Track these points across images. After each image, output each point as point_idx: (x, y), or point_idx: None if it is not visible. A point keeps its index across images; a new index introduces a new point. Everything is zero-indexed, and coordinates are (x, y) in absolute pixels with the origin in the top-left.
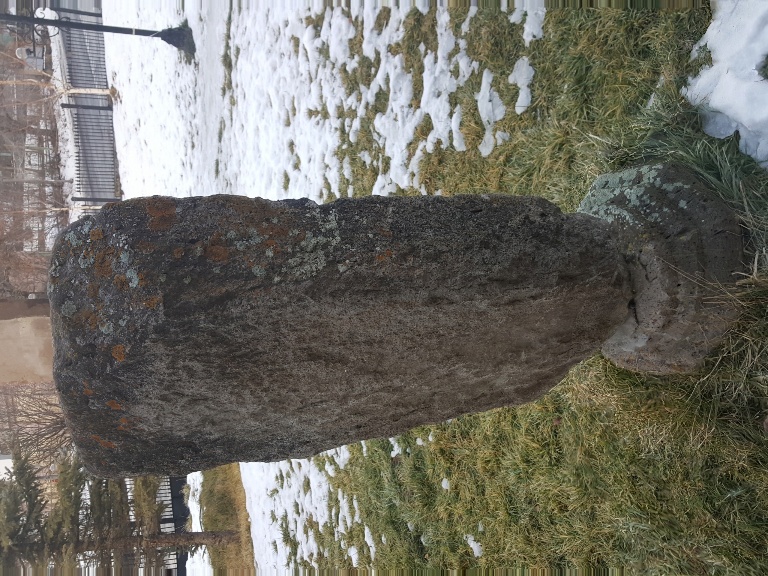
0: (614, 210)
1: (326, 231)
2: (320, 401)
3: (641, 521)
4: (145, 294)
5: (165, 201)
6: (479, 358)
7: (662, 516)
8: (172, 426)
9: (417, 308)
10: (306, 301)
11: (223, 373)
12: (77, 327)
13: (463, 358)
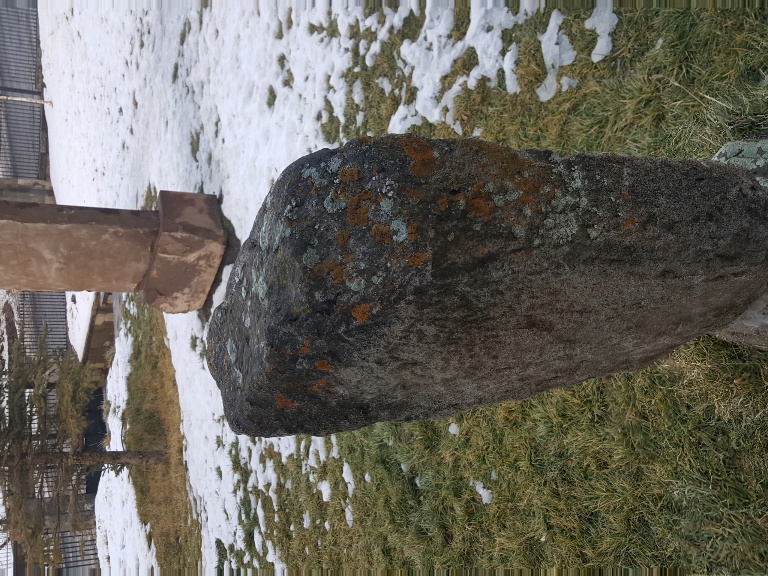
0: (763, 183)
1: (573, 191)
2: (505, 368)
3: (700, 485)
4: (412, 251)
5: (421, 143)
6: (648, 330)
7: (729, 483)
8: (366, 389)
9: (646, 281)
10: (562, 269)
11: (448, 338)
12: (318, 280)
13: (638, 329)
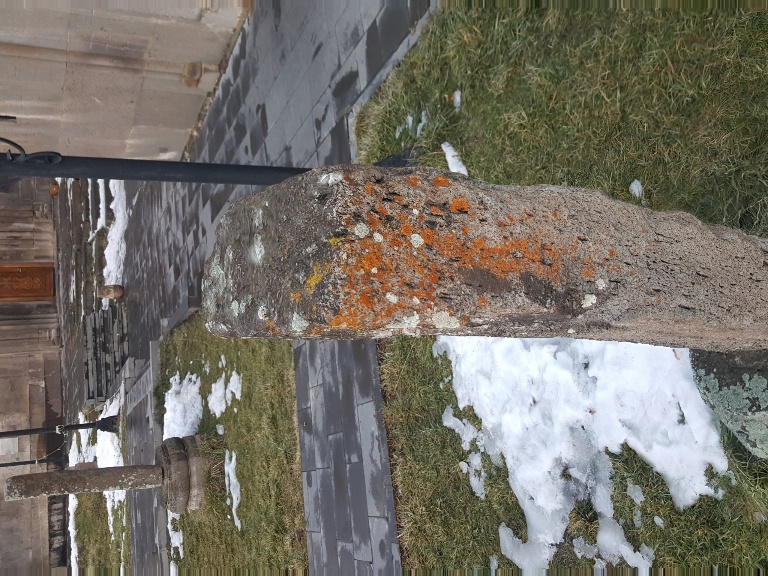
0: (694, 375)
1: None
2: None
3: None
4: None
5: None
6: None
7: None
8: None
9: None
10: None
11: None
12: None
13: None
